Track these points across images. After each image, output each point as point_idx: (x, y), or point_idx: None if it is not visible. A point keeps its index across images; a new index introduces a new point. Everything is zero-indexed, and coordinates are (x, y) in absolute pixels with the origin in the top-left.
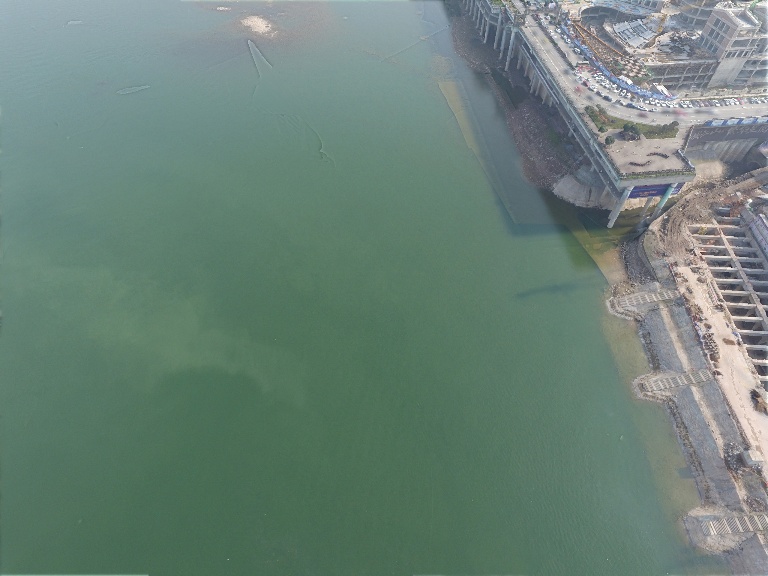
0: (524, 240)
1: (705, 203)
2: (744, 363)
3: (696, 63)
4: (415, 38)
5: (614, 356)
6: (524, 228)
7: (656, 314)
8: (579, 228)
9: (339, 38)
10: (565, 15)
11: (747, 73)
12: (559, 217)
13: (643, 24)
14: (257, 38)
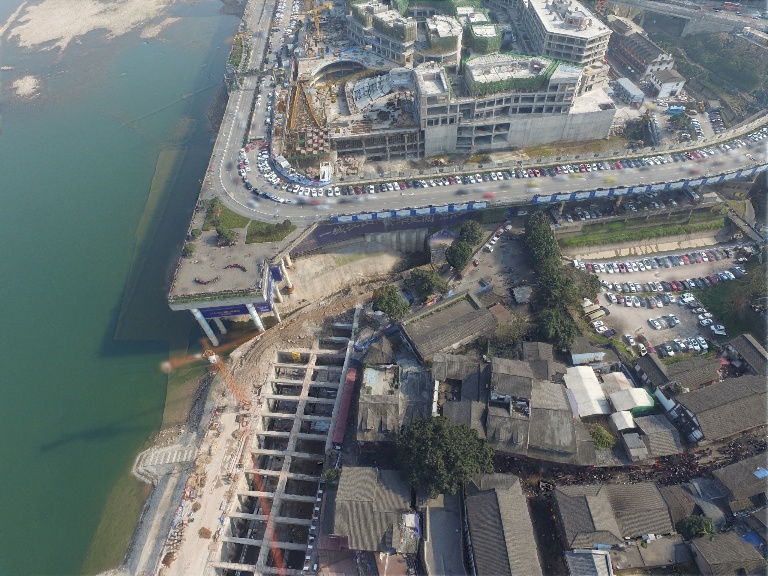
0: (105, 364)
1: (319, 318)
2: (201, 568)
3: (395, 133)
4: (177, 97)
5: (94, 539)
6: (117, 347)
7: (165, 481)
8: (181, 346)
9: (98, 99)
10: (282, 76)
11: (467, 140)
12: (170, 330)
13: (378, 82)
14: (13, 102)
